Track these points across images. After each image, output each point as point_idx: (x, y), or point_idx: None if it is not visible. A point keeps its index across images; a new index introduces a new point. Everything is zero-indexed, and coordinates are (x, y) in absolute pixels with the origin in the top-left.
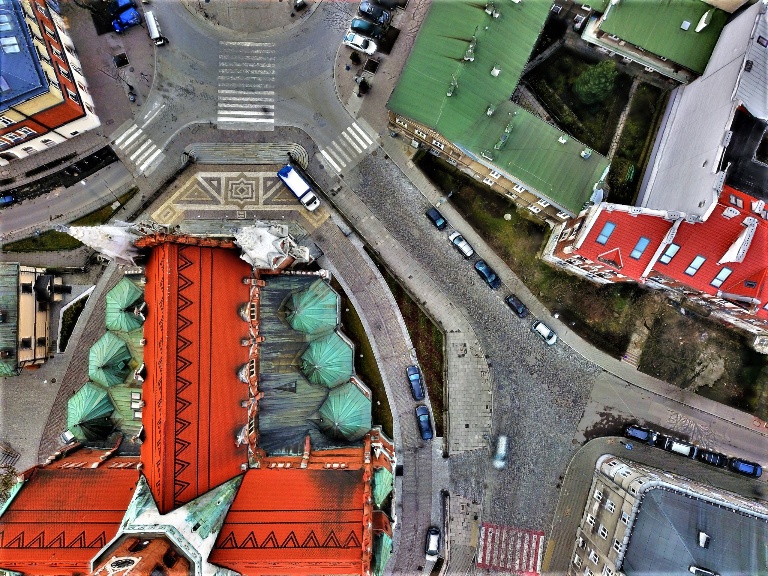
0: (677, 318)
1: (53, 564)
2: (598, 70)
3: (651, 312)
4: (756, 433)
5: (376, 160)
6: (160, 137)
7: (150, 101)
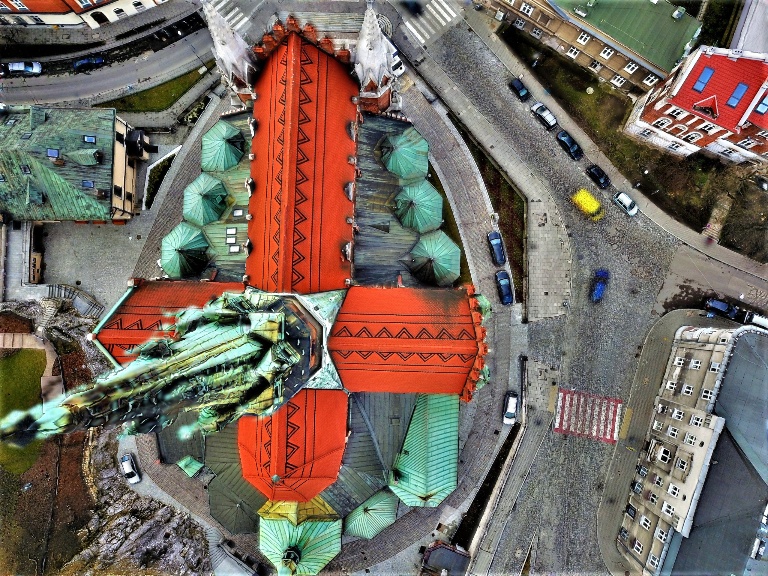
0: (759, 194)
1: None
2: None
3: (732, 188)
4: None
5: (459, 32)
6: (247, 5)
7: None
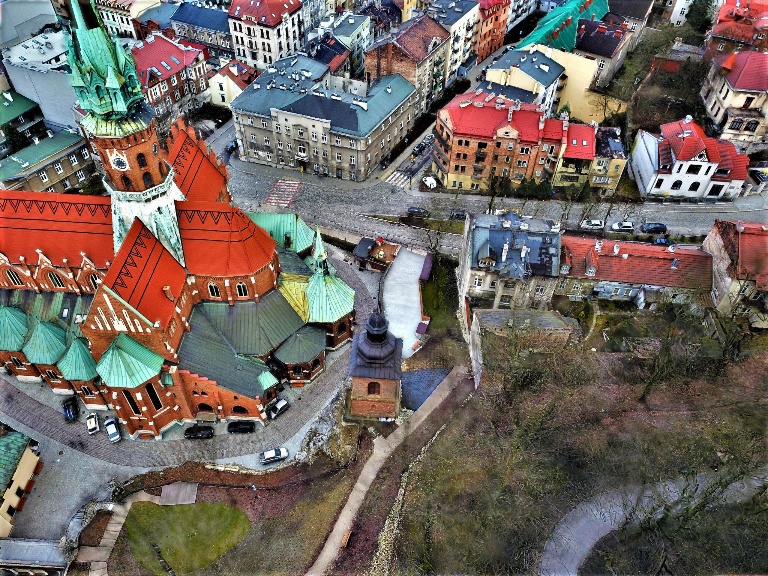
0: None
1: (133, 263)
2: (7, 131)
3: None
4: None
5: None
6: None
7: None
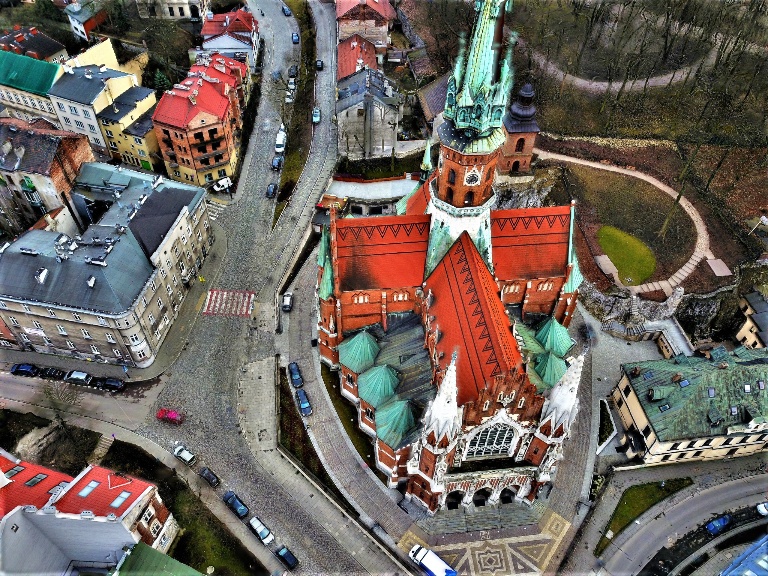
0: None
1: None
2: None
3: None
4: (6, 398)
5: None
6: None
7: None
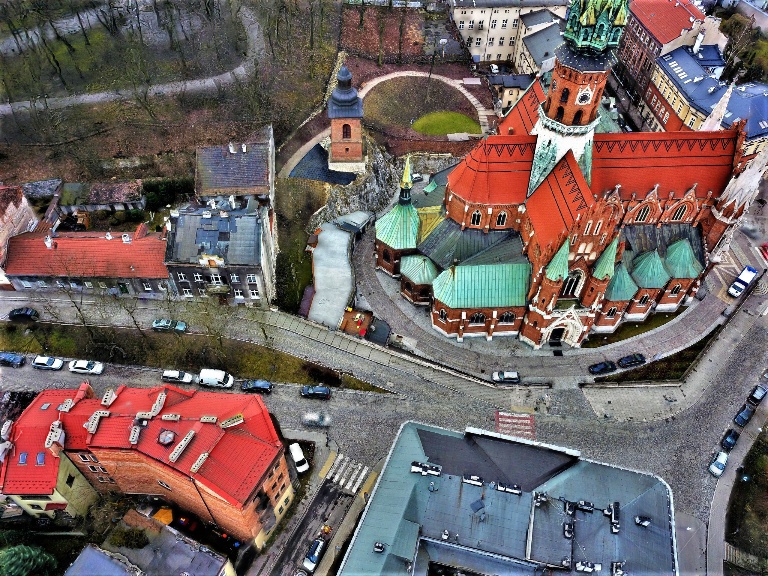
0: None
1: None
2: None
3: None
4: None
5: None
6: None
7: (745, 215)
